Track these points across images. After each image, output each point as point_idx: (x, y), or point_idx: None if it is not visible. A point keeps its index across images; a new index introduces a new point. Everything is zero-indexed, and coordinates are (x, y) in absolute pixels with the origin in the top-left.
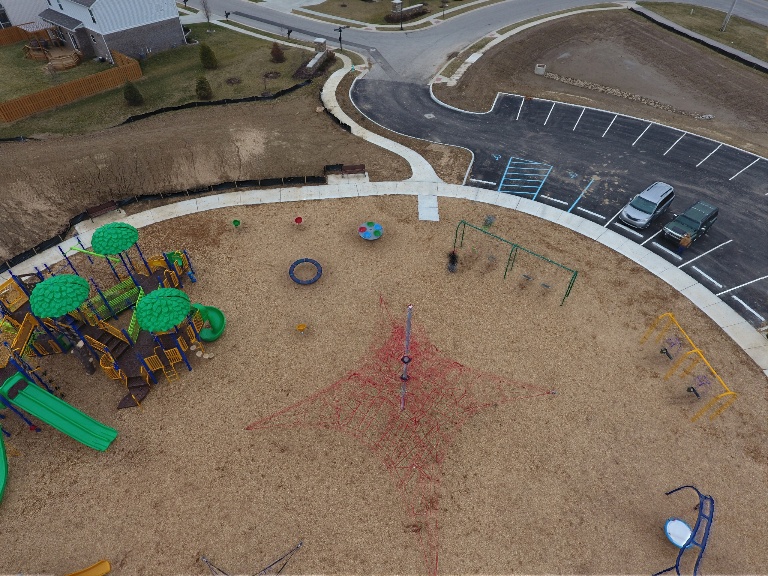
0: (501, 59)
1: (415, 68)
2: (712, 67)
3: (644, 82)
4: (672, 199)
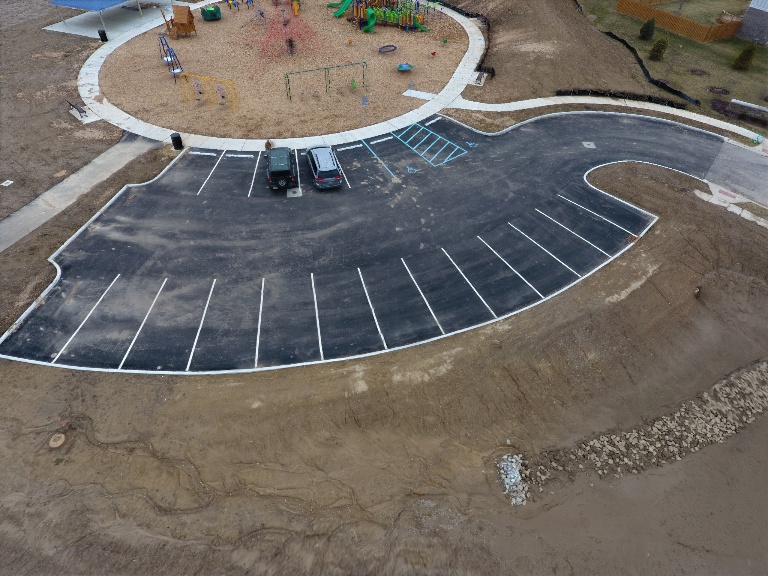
0: None
1: None
2: None
3: None
4: None
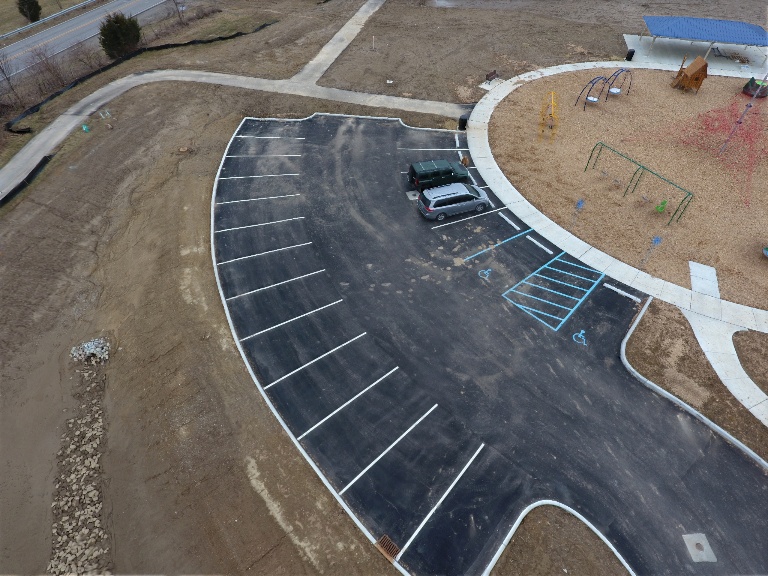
0: None
1: None
2: None
3: None
4: None
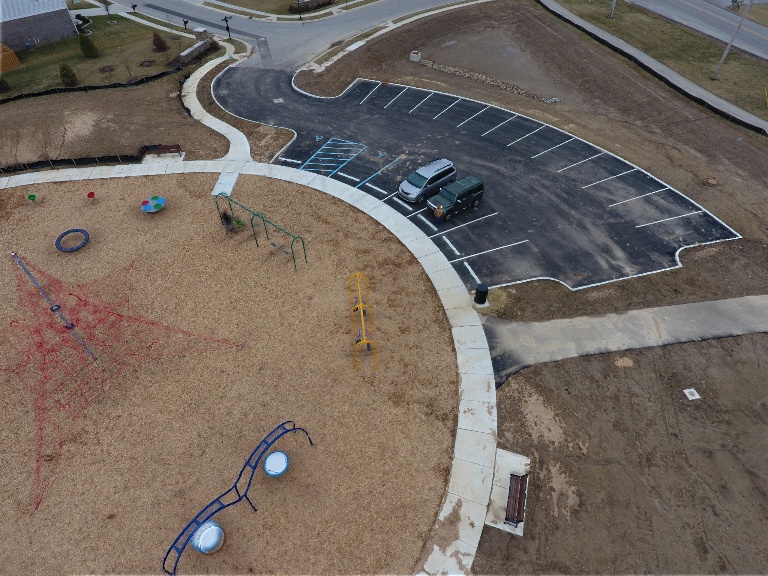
0: (379, 47)
1: (293, 56)
2: (582, 53)
3: (514, 68)
4: (452, 175)
